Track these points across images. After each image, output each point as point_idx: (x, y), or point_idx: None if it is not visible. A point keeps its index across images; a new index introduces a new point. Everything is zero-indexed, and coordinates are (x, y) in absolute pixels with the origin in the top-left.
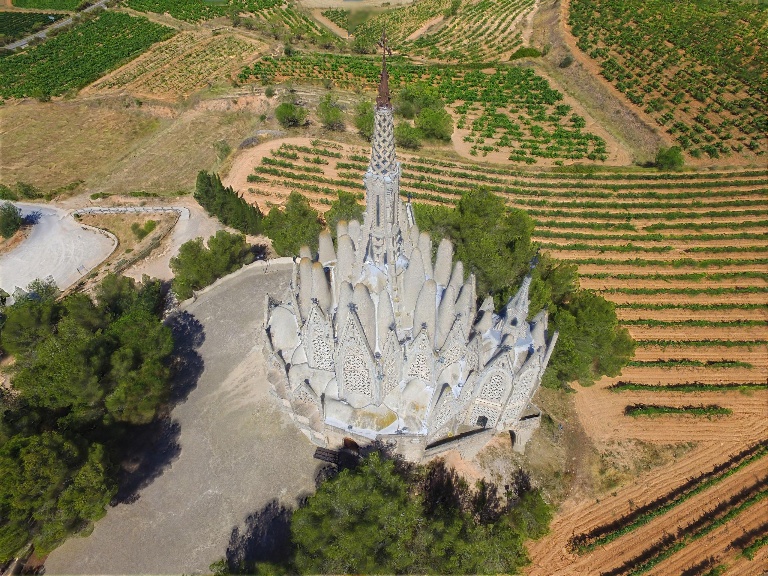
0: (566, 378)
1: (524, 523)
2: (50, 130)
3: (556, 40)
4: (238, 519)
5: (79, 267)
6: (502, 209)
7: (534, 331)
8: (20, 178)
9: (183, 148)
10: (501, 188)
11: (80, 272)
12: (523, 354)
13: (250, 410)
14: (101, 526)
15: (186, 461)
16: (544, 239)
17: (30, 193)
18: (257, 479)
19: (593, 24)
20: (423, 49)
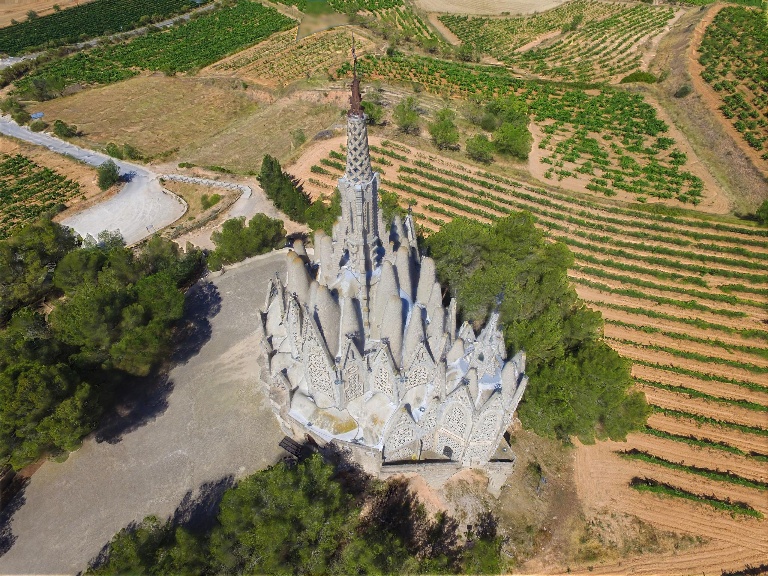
0: (567, 430)
1: (470, 569)
2: (167, 101)
3: (678, 67)
4: (195, 484)
5: (148, 226)
6: (539, 238)
7: (503, 371)
8: (132, 140)
9: (268, 132)
10: (563, 216)
11: (149, 230)
12: (487, 392)
13: (237, 386)
14: (84, 457)
15: (169, 418)
16: (595, 278)
17: (133, 154)
18: (223, 451)
19: (727, 53)
20: (530, 62)
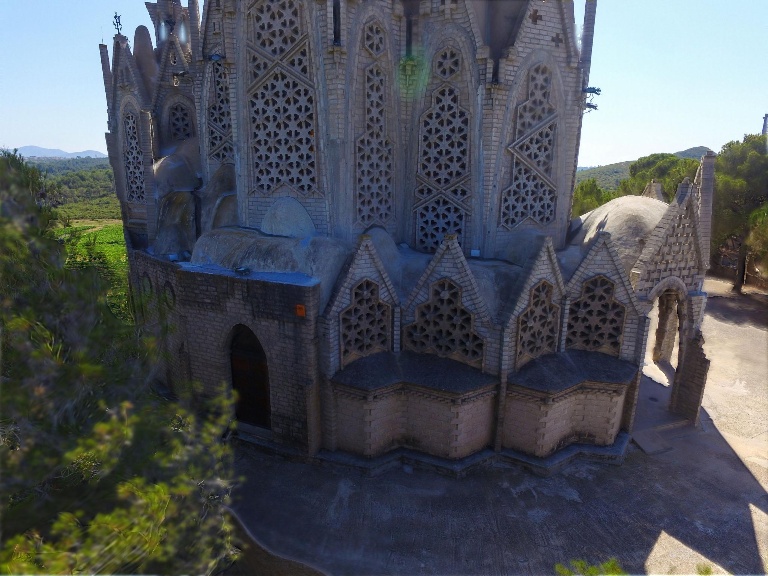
0: None
1: None
2: None
3: None
4: None
5: None
6: None
7: None
8: None
9: None
10: None
11: None
12: None
13: None
14: None
15: None
16: None
17: None
18: None
19: None
20: None
